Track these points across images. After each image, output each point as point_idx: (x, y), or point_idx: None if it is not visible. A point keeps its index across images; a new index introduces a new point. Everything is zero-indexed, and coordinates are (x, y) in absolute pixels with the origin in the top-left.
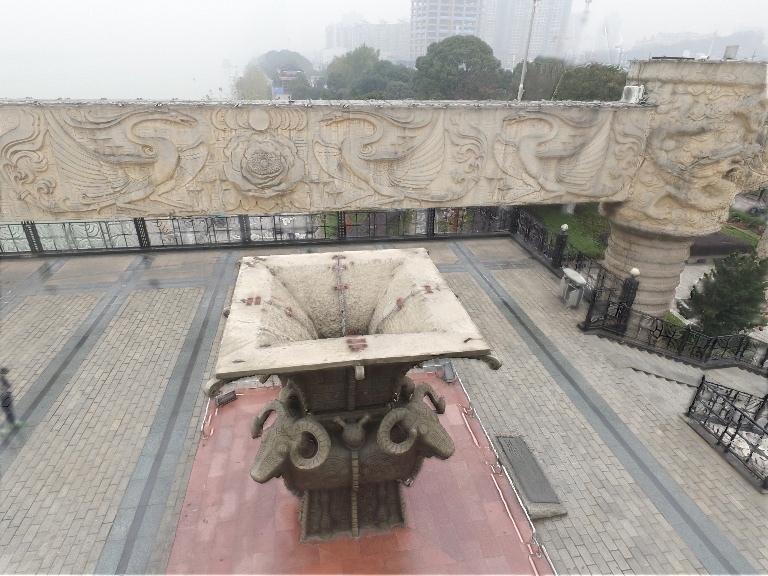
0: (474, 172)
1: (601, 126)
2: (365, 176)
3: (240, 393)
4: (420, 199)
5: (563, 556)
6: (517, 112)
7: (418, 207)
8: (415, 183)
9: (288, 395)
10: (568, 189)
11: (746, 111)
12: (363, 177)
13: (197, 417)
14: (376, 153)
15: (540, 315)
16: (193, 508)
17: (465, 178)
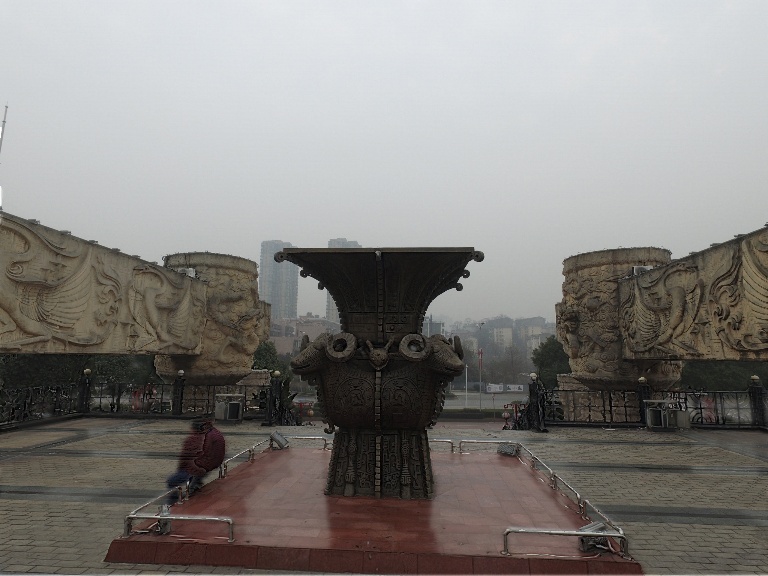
0: (113, 315)
1: (186, 290)
2: (10, 303)
3: (155, 521)
4: (67, 340)
5: None
6: (143, 264)
7: (62, 352)
8: (62, 320)
9: (388, 347)
10: (173, 340)
11: (255, 288)
12: (7, 304)
13: (143, 572)
14: (25, 276)
15: (230, 429)
16: (364, 544)
17: (107, 320)
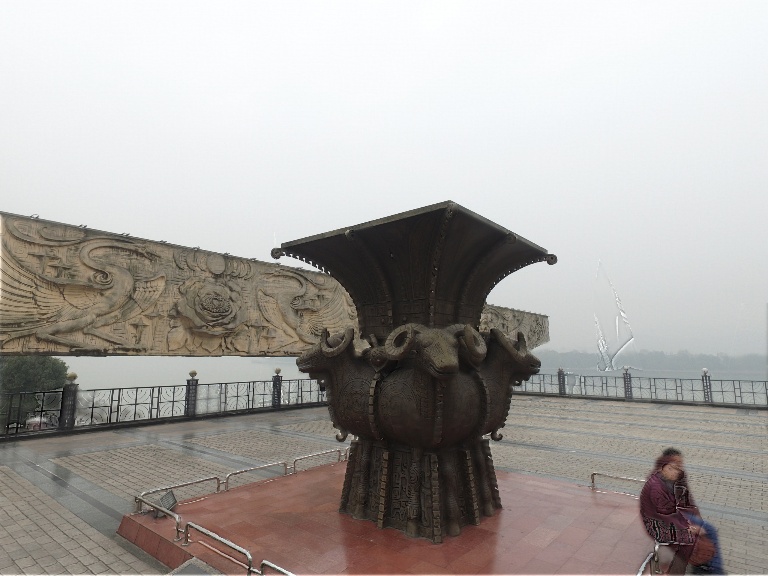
0: None
1: None
2: None
3: None
4: None
5: (135, 575)
6: None
7: None
8: None
9: None
10: None
11: None
12: None
13: None
14: None
15: None
16: None
17: None
